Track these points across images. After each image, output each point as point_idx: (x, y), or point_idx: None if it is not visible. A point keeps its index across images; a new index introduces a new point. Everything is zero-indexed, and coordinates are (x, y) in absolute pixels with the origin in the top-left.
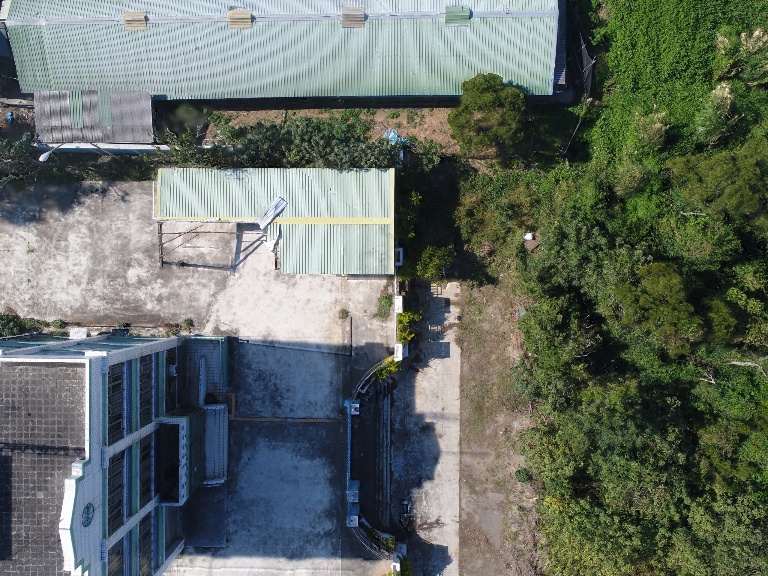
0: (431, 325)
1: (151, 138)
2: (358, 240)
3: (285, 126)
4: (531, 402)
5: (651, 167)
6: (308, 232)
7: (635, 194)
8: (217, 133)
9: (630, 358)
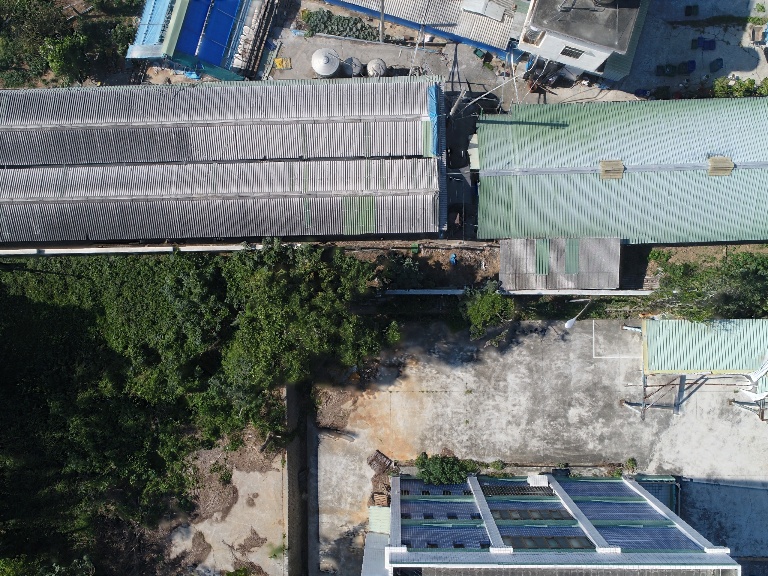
0: None
1: (616, 284)
2: None
3: (733, 264)
4: None
5: None
6: None
7: None
8: (658, 270)
9: None
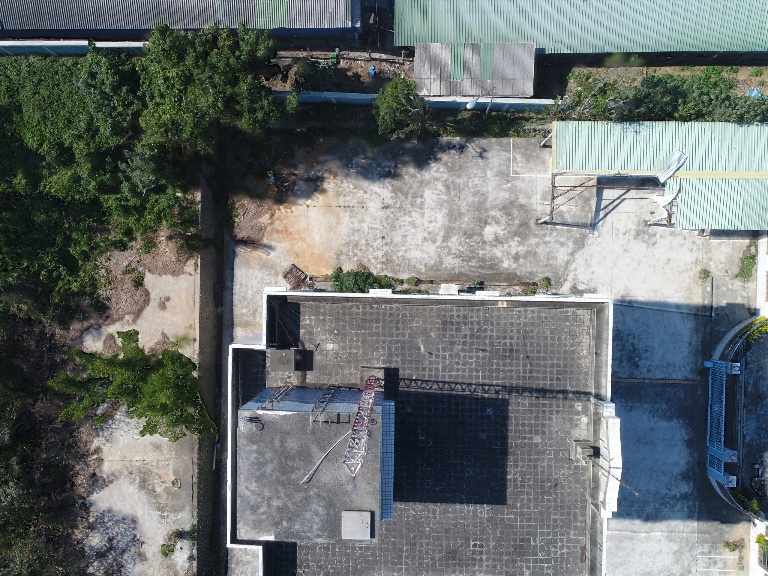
0: None
1: (531, 92)
2: (759, 195)
3: None
4: None
5: None
6: (708, 186)
7: None
8: None
9: None
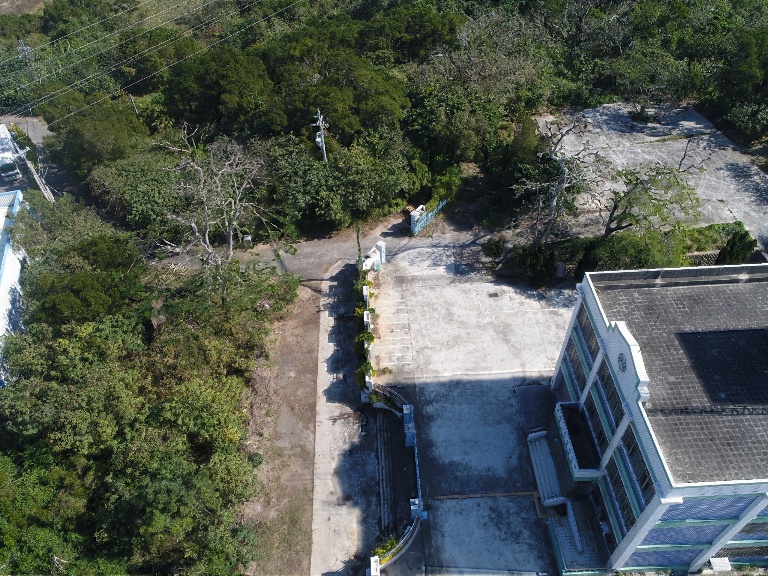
0: None
1: None
2: None
3: None
4: None
5: None
6: None
7: None
8: None
9: None
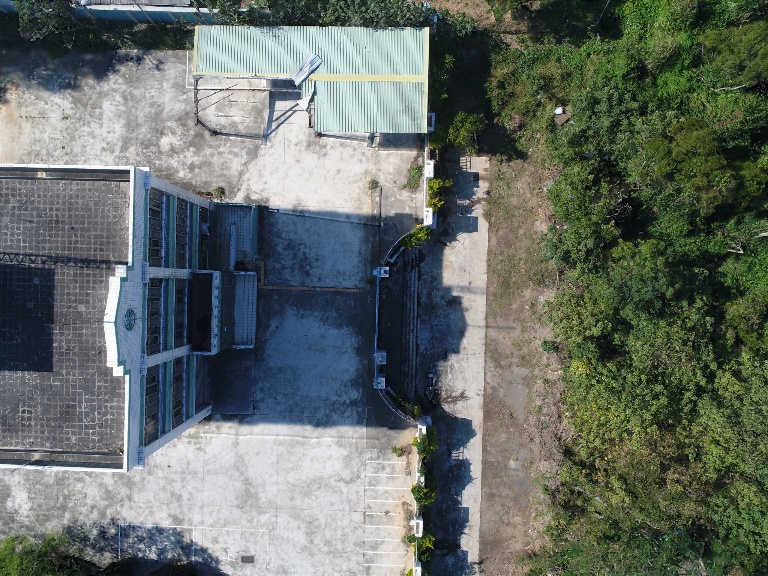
0: (460, 199)
1: (188, 0)
2: (392, 98)
3: None
4: (558, 273)
5: (682, 42)
6: (342, 89)
7: (666, 68)
8: (251, 3)
9: (658, 231)
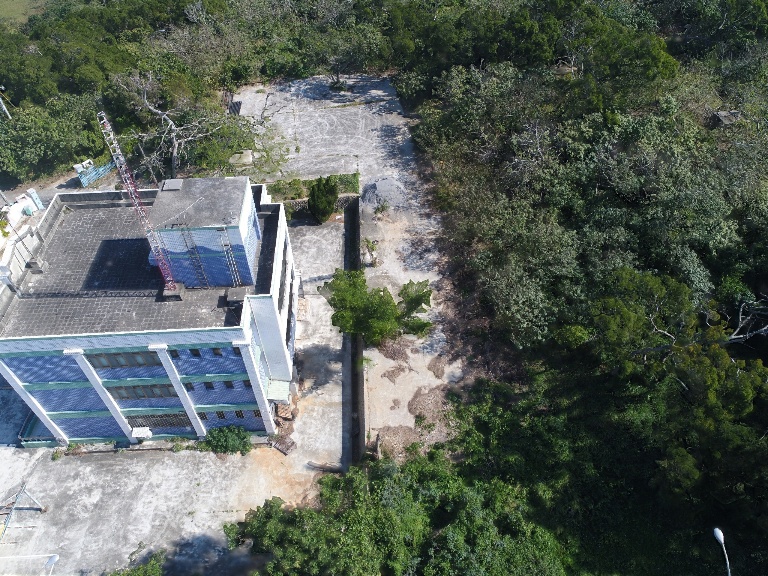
0: None
1: None
2: None
3: None
4: None
5: None
6: None
7: None
8: None
9: None
